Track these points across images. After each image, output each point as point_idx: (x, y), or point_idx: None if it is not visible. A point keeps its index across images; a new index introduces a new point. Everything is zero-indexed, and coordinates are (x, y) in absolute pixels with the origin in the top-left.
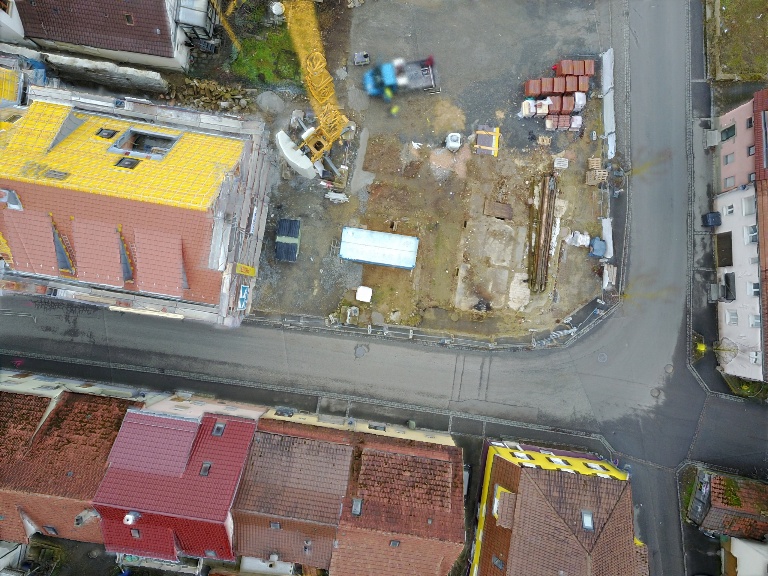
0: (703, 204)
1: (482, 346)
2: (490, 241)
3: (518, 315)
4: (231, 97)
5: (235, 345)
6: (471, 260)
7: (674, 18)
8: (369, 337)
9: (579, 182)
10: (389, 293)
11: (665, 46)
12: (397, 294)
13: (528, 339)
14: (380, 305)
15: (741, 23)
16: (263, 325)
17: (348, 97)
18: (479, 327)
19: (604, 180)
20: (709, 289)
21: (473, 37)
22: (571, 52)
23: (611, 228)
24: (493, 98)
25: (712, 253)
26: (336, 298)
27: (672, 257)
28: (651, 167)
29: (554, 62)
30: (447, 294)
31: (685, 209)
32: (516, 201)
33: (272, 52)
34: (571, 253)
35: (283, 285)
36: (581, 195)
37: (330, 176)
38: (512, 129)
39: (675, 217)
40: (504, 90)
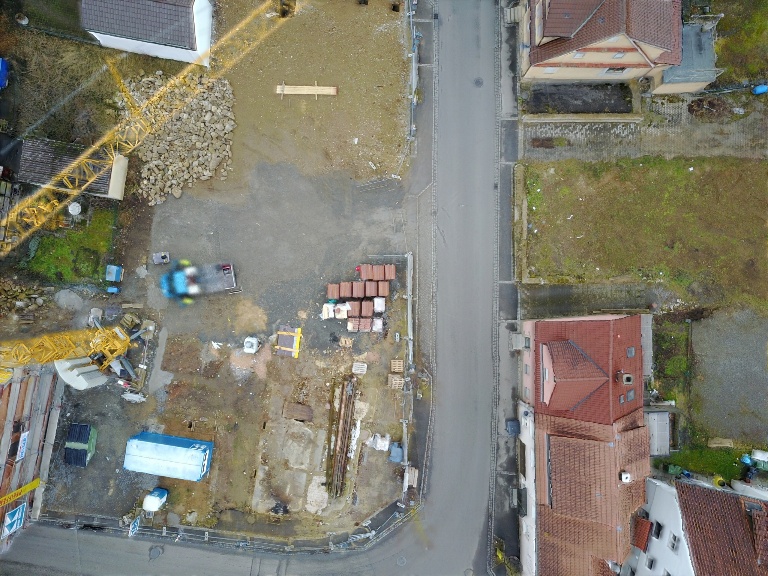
0: (507, 407)
1: (279, 549)
2: (289, 443)
3: (316, 518)
4: (26, 296)
5: (28, 545)
6: (269, 462)
7: (483, 218)
8: (164, 538)
9: (381, 384)
10: (185, 494)
11: (473, 246)
12: (193, 495)
13: (326, 542)
14: (176, 506)
15: (551, 224)
16: (56, 525)
17: (147, 296)
18: (276, 530)
19: (400, 388)
20: (511, 494)
21: (276, 236)
22: (376, 252)
23: (406, 438)
24: (295, 298)
25: (515, 457)
26: (132, 498)
27: (475, 460)
28: (456, 369)
29: (358, 262)
30: (244, 496)
31: (489, 412)
32: (316, 403)
33: (71, 250)
34: (372, 455)
35: (78, 485)
36: (383, 397)
37: (126, 377)
38: (313, 331)
39: (479, 419)
40: (306, 290)
